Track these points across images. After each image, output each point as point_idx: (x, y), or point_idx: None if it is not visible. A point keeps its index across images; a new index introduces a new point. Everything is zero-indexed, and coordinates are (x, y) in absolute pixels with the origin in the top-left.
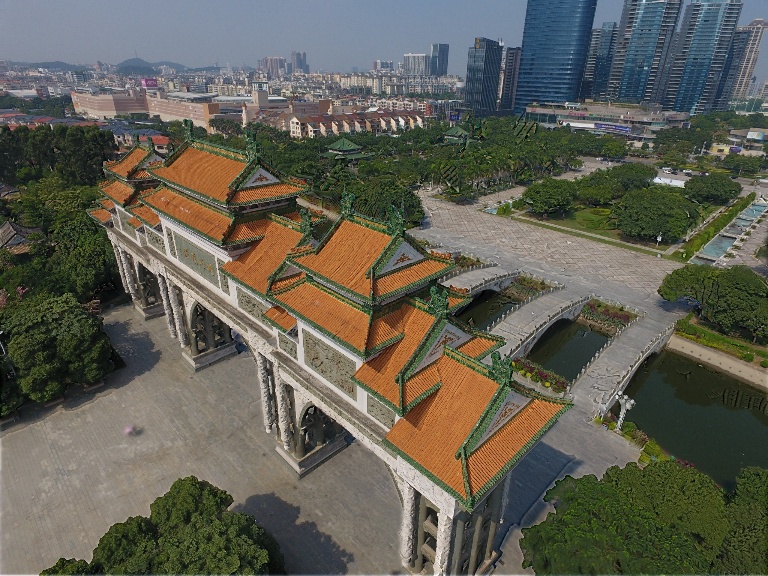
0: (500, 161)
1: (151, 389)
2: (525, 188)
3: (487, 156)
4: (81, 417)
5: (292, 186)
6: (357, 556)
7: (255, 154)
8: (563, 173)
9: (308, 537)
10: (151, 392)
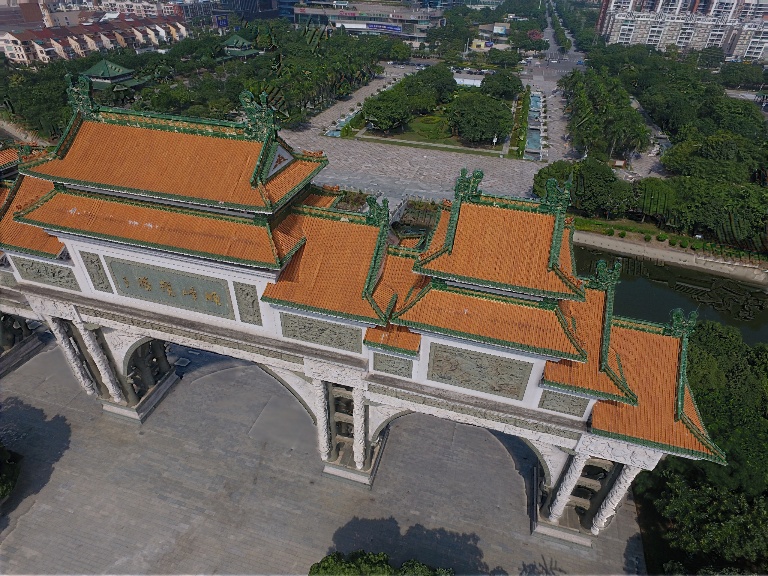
0: (320, 76)
1: (94, 471)
2: (346, 103)
3: (306, 71)
4: (13, 557)
5: (306, 162)
6: (479, 533)
7: (271, 127)
8: (369, 82)
9: (424, 541)
10: (98, 475)
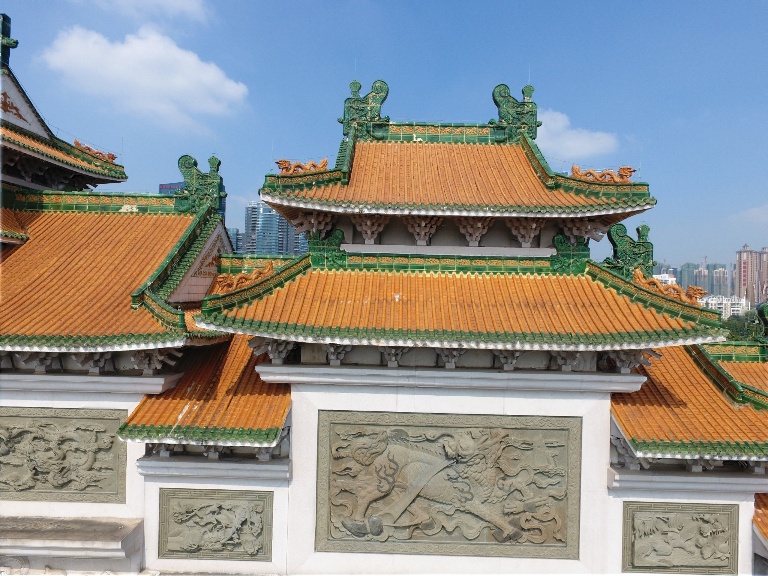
0: None
1: None
2: None
3: None
4: None
5: (78, 159)
6: None
7: None
8: None
9: None
10: None
